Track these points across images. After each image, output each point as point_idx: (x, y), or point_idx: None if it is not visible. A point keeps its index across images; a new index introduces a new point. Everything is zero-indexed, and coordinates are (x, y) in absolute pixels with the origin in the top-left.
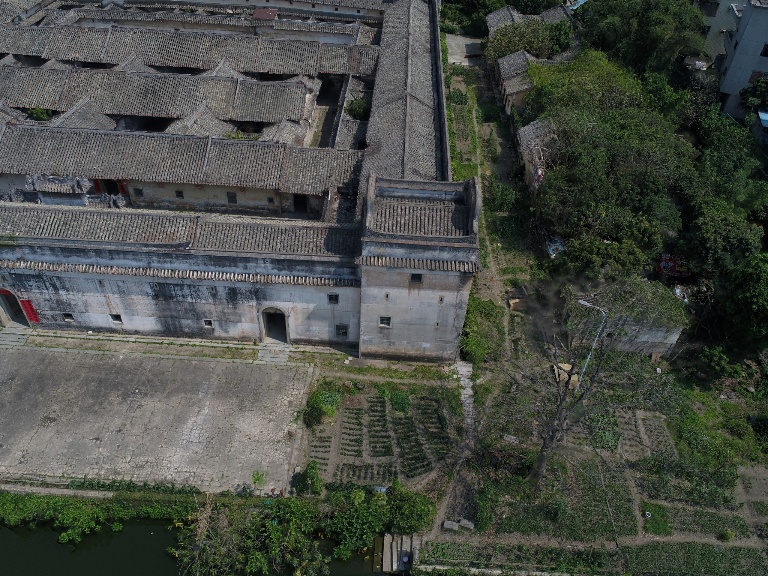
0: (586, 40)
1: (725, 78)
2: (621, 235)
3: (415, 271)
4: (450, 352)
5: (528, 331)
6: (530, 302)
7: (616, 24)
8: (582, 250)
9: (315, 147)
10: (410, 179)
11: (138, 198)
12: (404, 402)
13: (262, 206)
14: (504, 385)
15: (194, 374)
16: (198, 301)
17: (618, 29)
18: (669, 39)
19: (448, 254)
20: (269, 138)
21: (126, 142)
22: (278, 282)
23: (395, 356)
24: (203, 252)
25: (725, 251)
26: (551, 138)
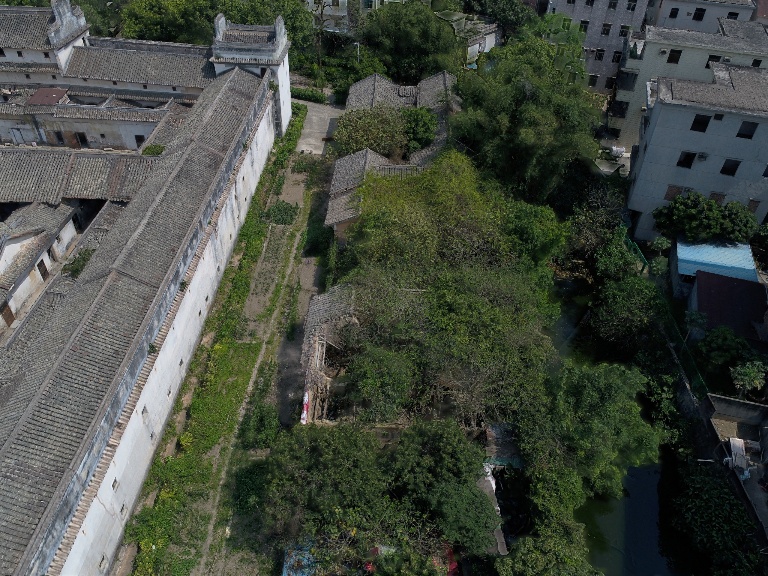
0: (453, 133)
1: (633, 192)
2: None
3: None
4: None
5: None
6: None
7: (481, 120)
8: None
9: None
10: None
11: None
12: None
13: None
14: None
15: None
16: None
17: (485, 126)
18: (552, 141)
19: None
20: None
21: None
22: None
23: None
24: None
25: None
26: (347, 322)
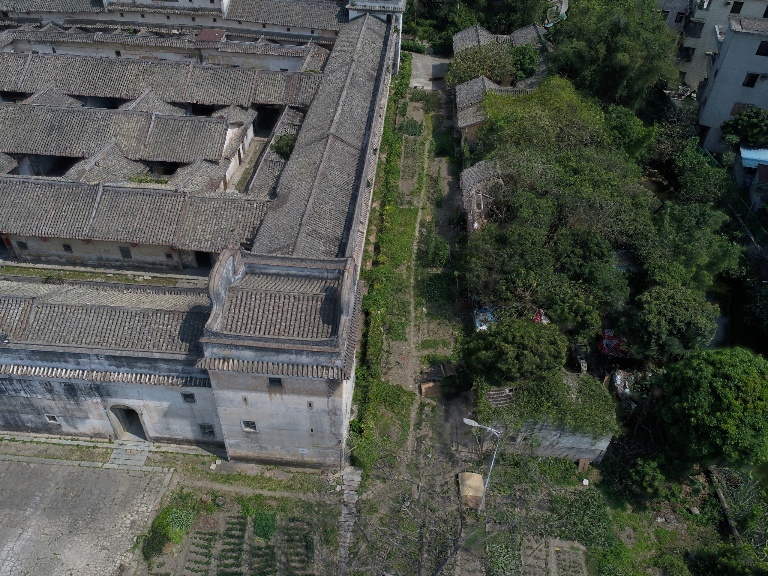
0: (553, 65)
1: (704, 109)
2: (552, 311)
3: (272, 375)
4: (333, 458)
5: (436, 426)
6: (446, 386)
7: (582, 49)
8: (498, 334)
9: (242, 187)
10: (301, 246)
11: (23, 251)
12: (268, 525)
13: (160, 262)
14: (395, 501)
15: (28, 482)
16: (34, 396)
17: (585, 55)
18: (641, 66)
19: (307, 358)
20: (178, 182)
21: (8, 190)
22: (117, 380)
23: (270, 461)
24: (24, 346)
25: (671, 335)
26: (495, 183)
